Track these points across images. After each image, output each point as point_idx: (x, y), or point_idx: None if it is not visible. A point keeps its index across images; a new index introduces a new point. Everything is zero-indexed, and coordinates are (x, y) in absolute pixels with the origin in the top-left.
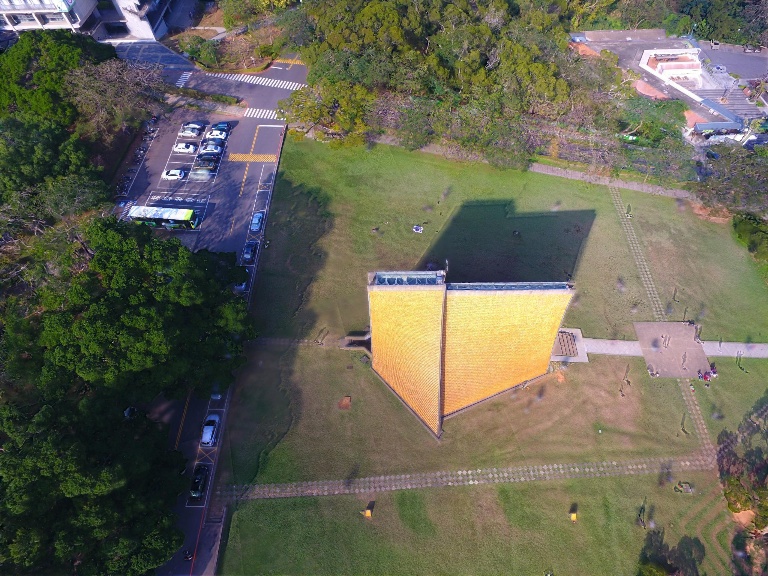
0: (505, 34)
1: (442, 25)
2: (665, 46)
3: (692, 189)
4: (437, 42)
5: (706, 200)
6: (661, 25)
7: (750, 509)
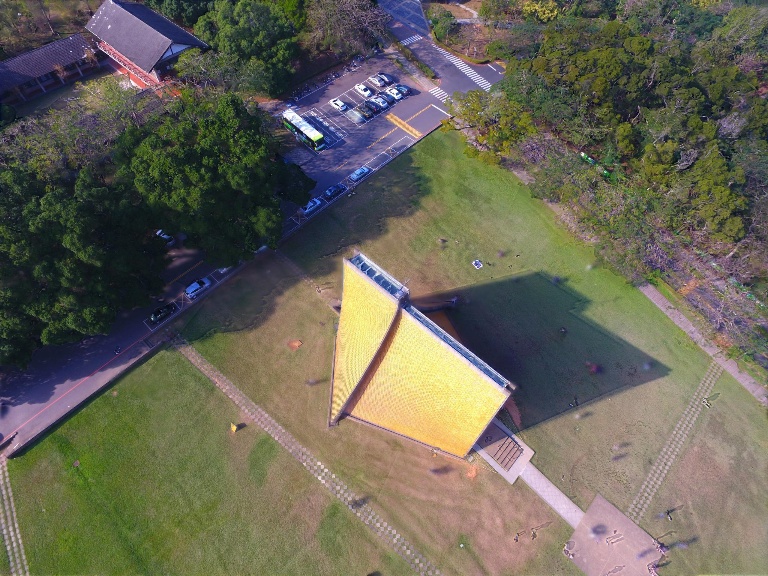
0: None
1: (666, 103)
2: None
3: None
4: (645, 116)
5: None
6: None
7: None
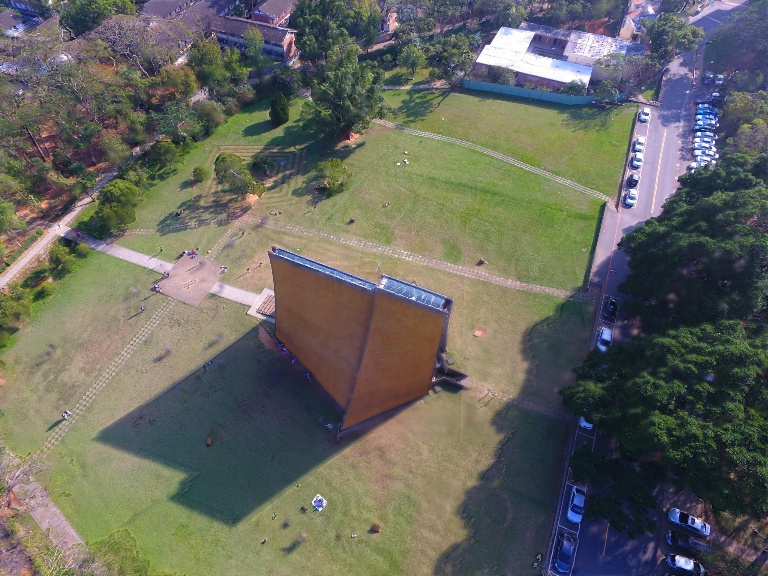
0: None
1: None
2: None
3: None
4: None
5: None
6: None
7: None
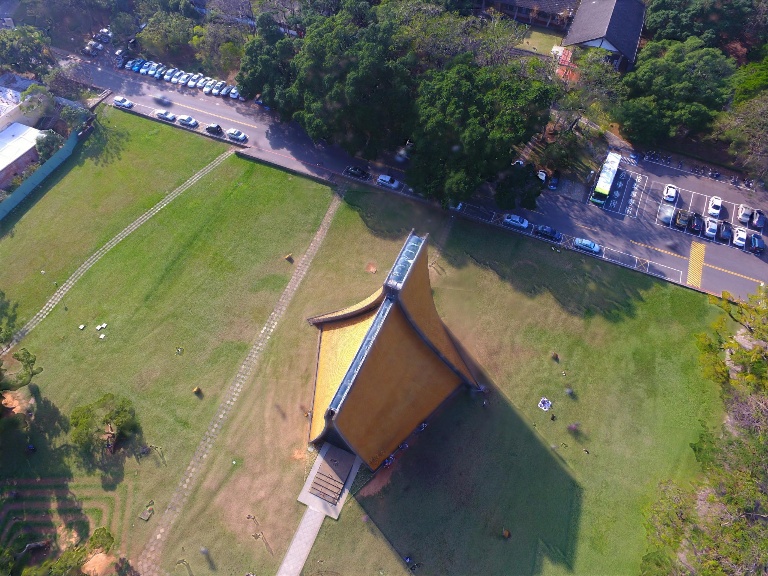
0: None
1: None
2: None
3: None
4: None
5: None
6: None
7: None
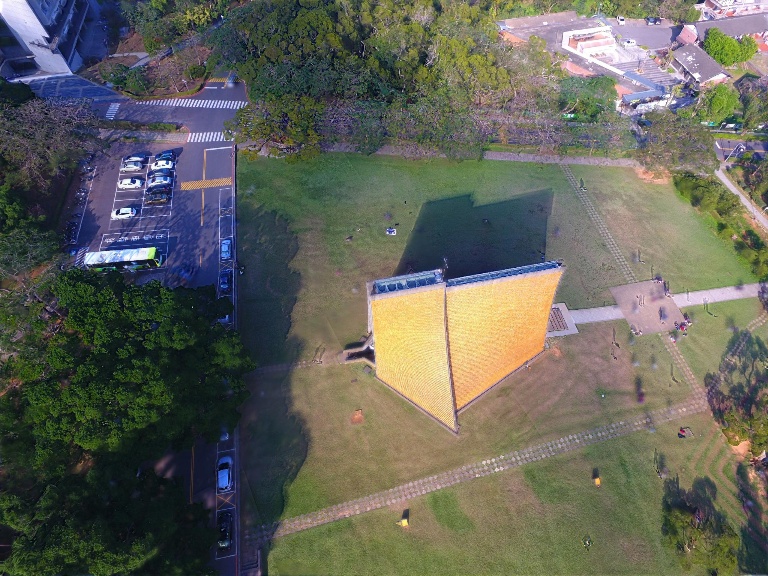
0: (435, 30)
1: (375, 27)
2: (581, 26)
3: (632, 156)
4: (373, 45)
5: (649, 165)
6: (571, 7)
7: (747, 440)
